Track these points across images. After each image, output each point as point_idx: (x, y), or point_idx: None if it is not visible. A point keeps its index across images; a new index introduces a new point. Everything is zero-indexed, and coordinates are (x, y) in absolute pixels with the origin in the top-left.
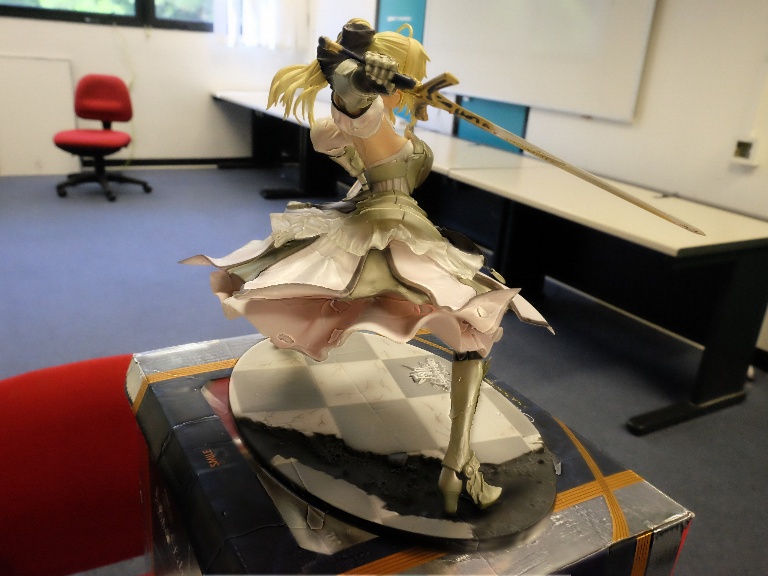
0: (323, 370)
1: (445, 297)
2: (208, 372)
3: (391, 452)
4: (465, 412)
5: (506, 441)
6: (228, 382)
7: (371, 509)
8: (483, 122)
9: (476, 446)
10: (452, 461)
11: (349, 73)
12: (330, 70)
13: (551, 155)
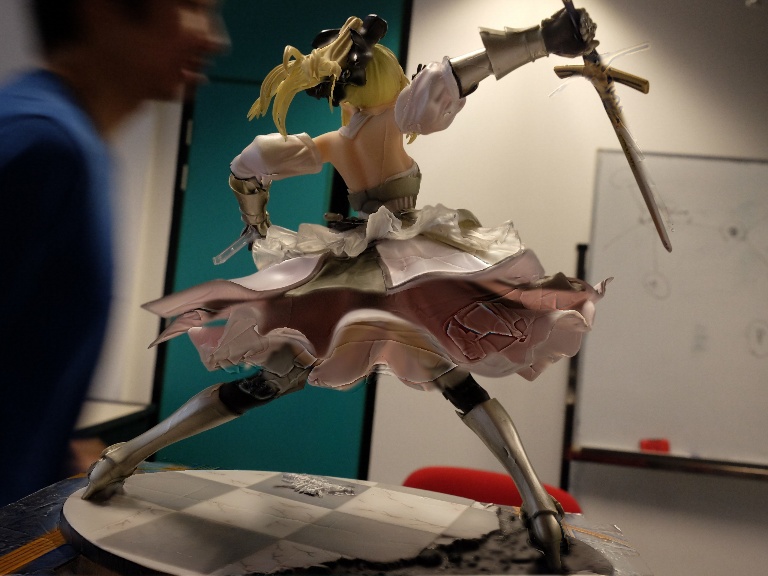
0: (206, 510)
1: None
2: (32, 561)
3: (417, 552)
4: (519, 452)
5: (469, 513)
6: (73, 569)
7: None
8: (620, 105)
9: (460, 523)
10: (541, 506)
11: (529, 30)
12: (364, 58)
13: (642, 147)
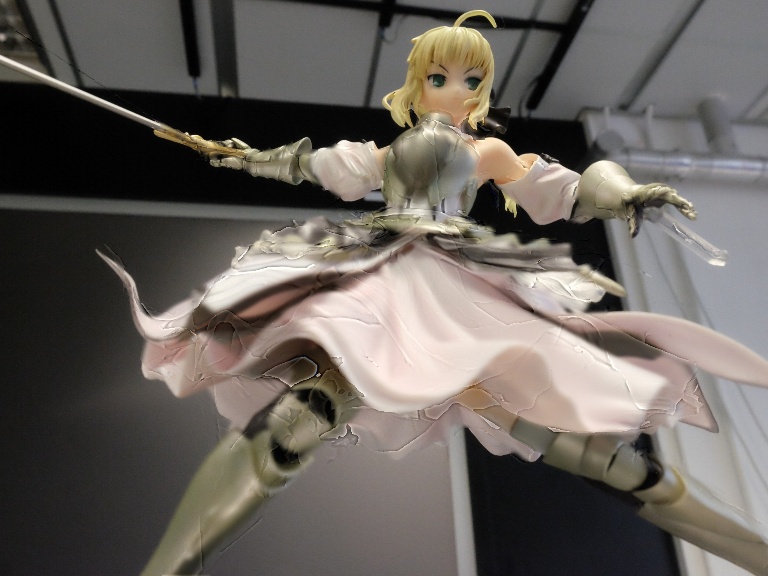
0: None
1: None
2: None
3: None
4: None
5: None
6: None
7: None
8: None
9: None
10: None
11: None
12: None
13: None
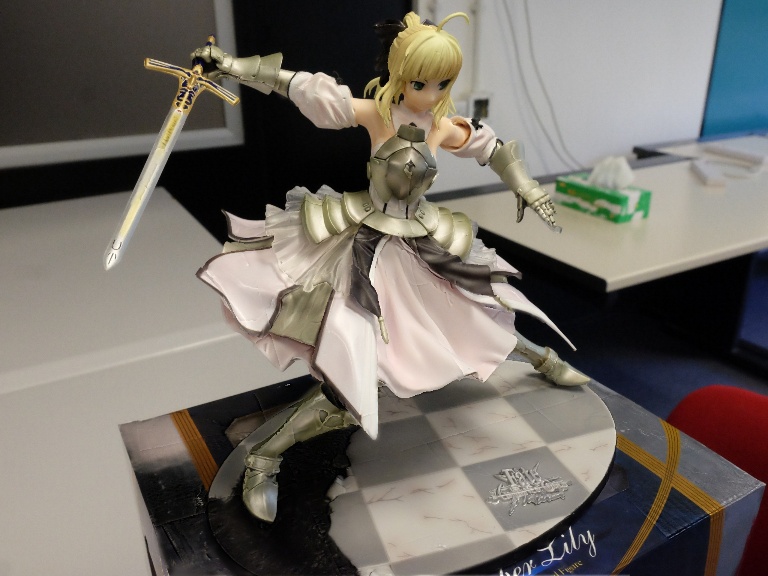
0: (496, 406)
1: (231, 270)
2: None
3: (350, 456)
4: None
5: (376, 545)
6: None
7: (259, 440)
8: None
9: (364, 517)
10: None
11: None
12: None
13: None
